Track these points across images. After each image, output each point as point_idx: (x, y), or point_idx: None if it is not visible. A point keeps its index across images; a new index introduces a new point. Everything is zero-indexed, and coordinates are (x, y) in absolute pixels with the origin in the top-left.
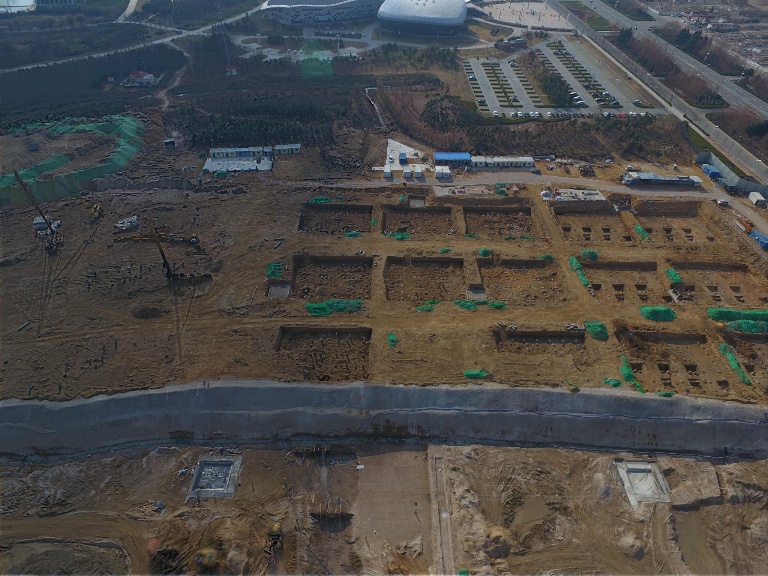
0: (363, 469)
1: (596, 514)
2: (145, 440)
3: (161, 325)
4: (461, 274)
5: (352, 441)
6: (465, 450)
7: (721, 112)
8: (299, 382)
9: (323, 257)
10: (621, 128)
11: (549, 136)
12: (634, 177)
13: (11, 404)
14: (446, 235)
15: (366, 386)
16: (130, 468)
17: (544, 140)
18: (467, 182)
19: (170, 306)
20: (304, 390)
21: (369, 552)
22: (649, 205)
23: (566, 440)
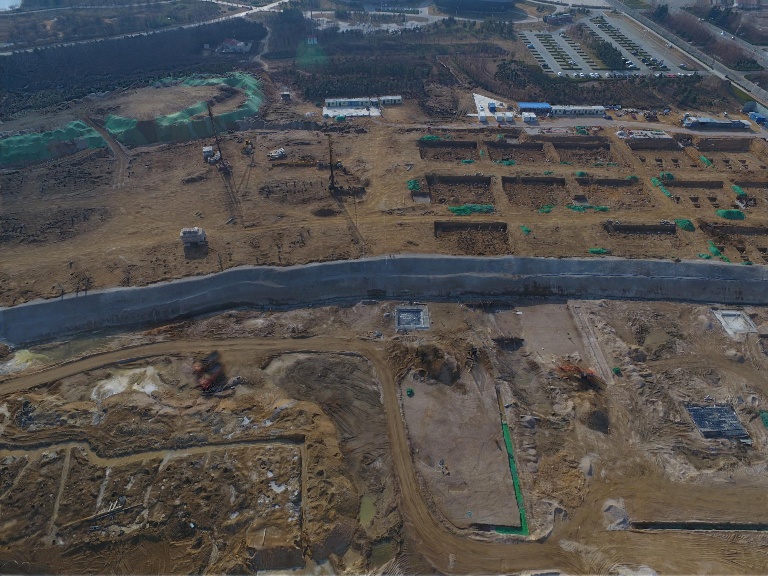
0: (522, 314)
1: (705, 339)
2: (349, 296)
3: (338, 221)
4: (564, 190)
5: (508, 298)
6: (597, 302)
7: (758, 73)
8: (463, 255)
9: (449, 177)
10: (673, 85)
11: (612, 92)
12: (694, 120)
13: (247, 268)
14: (545, 162)
15: (516, 258)
16: (345, 313)
17: (608, 95)
18: (552, 125)
19: (339, 209)
20: (468, 260)
21: (542, 360)
22: (708, 142)
23: (672, 296)
